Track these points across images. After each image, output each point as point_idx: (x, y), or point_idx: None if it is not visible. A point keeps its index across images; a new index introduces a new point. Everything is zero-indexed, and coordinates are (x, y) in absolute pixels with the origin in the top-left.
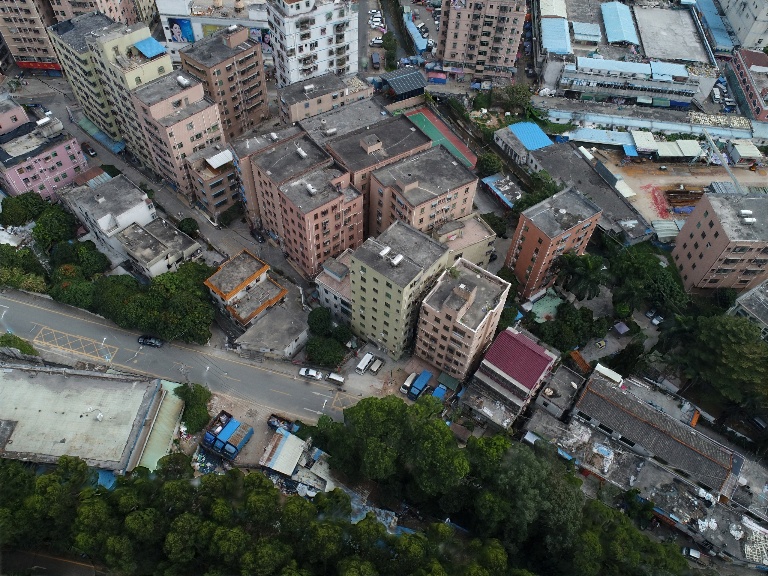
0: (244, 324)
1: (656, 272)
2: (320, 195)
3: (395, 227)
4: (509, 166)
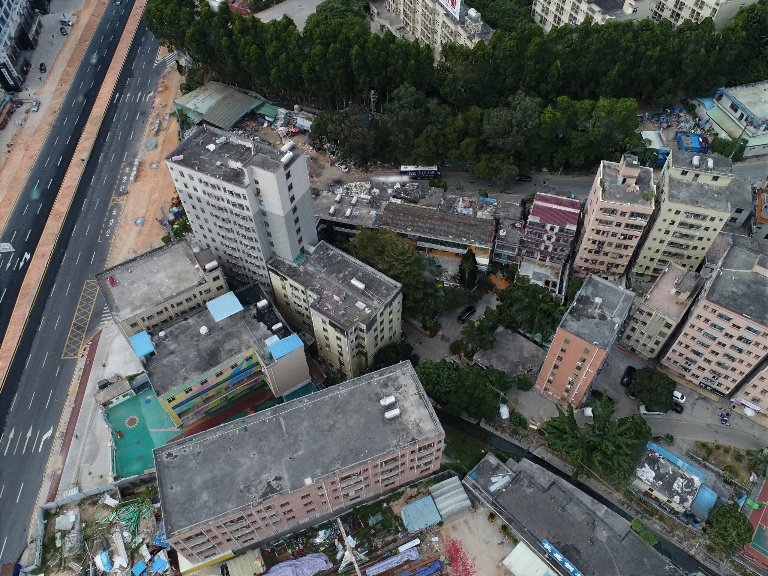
0: (758, 189)
1: (459, 378)
2: None
3: (727, 210)
4: None
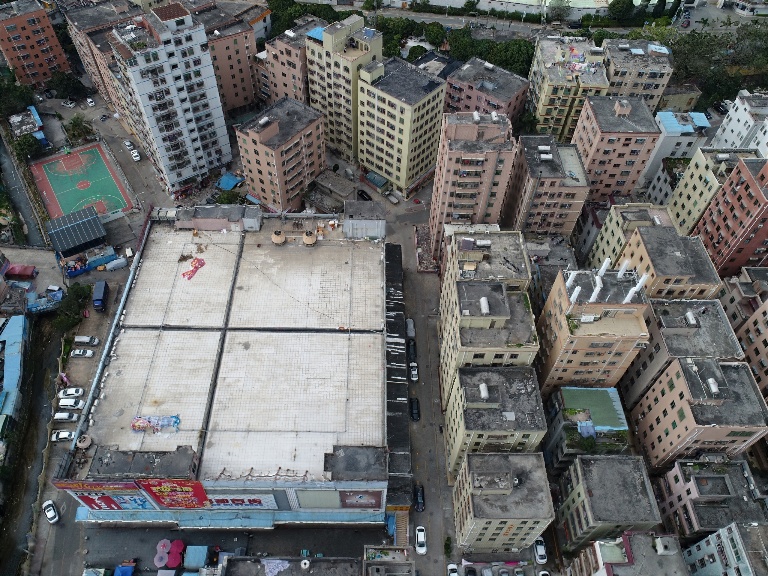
0: None
1: None
2: (186, 1)
3: None
4: (2, 178)
